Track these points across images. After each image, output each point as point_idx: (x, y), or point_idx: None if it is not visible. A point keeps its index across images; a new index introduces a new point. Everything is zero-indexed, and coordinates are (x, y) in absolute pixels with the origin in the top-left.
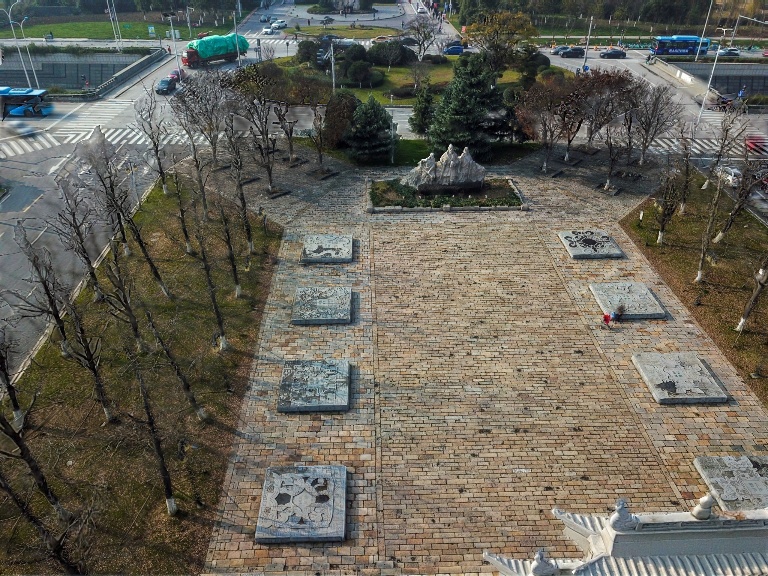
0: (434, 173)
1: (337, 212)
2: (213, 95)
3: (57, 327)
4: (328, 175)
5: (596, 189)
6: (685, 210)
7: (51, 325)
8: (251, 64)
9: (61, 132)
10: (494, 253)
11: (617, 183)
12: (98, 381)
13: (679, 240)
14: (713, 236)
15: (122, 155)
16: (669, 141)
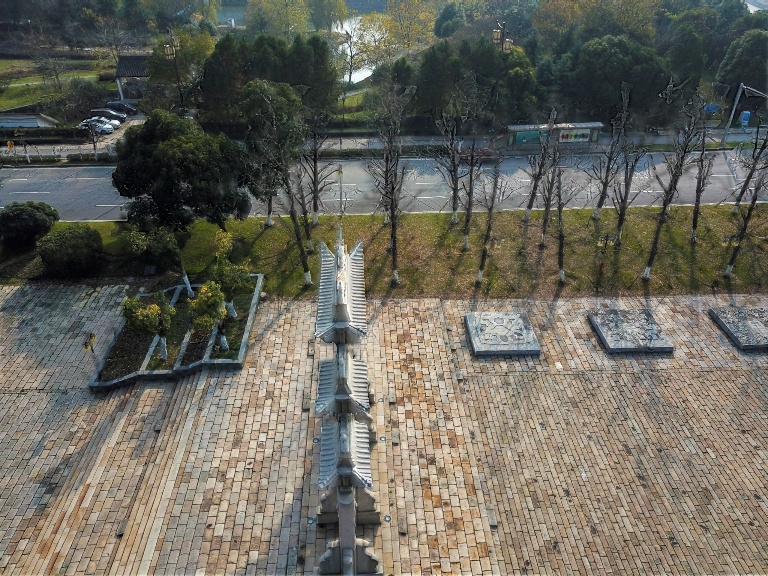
0: None
1: None
2: None
3: (600, 195)
4: None
5: None
6: None
7: (598, 191)
8: None
9: None
10: None
11: None
12: (548, 212)
13: None
14: None
15: None
16: None
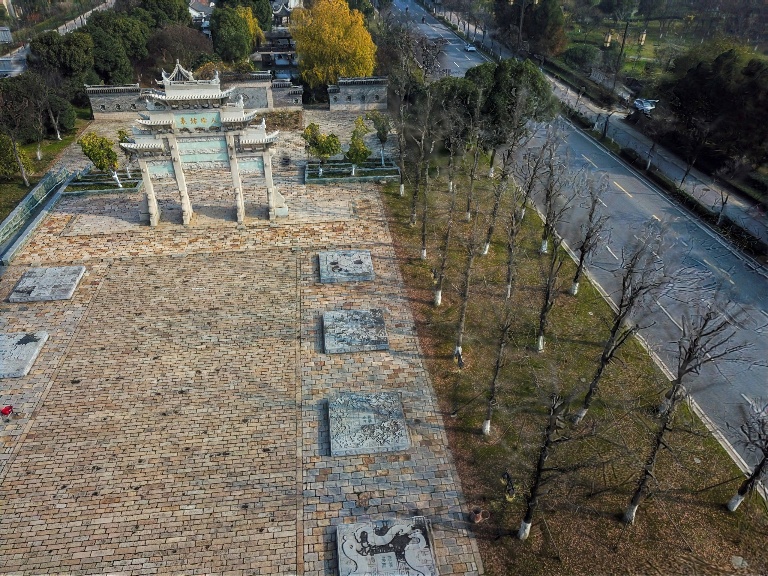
0: None
1: None
2: None
3: None
4: None
5: None
6: None
7: None
8: None
9: None
10: None
11: None
12: None
13: None
14: None
15: None
16: None
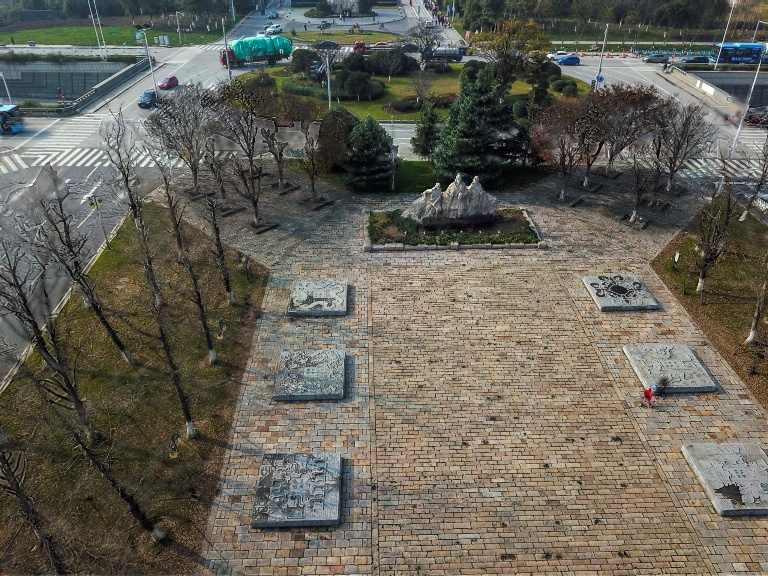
0: (440, 205)
1: (330, 251)
2: (193, 116)
3: None
4: (321, 204)
5: (621, 221)
6: (724, 248)
7: None
8: (236, 80)
9: (30, 152)
10: (510, 304)
11: (644, 213)
12: (24, 501)
13: (721, 287)
14: (759, 281)
15: (95, 180)
16: (696, 162)
